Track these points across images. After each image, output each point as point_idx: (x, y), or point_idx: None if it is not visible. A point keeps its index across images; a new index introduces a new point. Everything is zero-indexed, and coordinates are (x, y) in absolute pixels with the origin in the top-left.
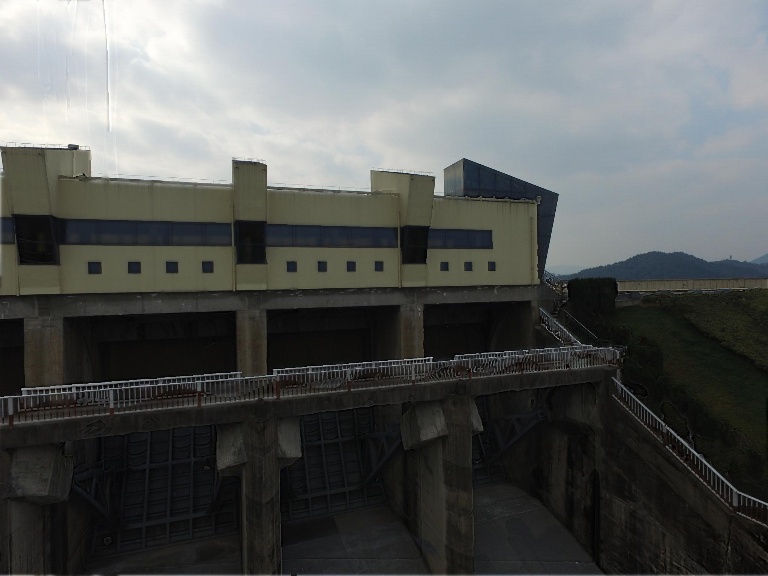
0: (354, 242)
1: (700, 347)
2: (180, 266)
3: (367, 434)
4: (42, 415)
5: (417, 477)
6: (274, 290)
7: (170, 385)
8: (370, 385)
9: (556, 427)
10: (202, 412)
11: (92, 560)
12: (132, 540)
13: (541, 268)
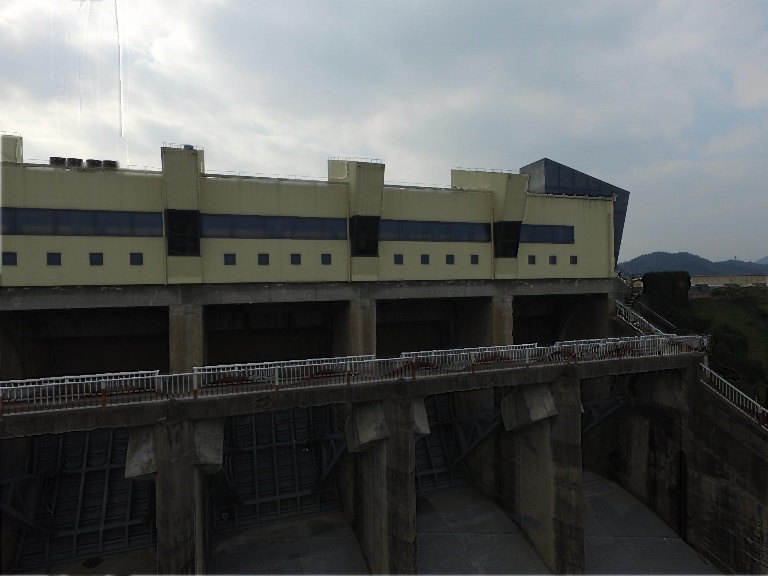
0: (452, 236)
1: None
2: (302, 258)
3: (454, 419)
4: (220, 390)
5: (515, 457)
6: (383, 281)
7: (324, 365)
8: (490, 368)
9: (637, 412)
10: (351, 390)
11: (215, 533)
12: (247, 516)
13: (614, 262)
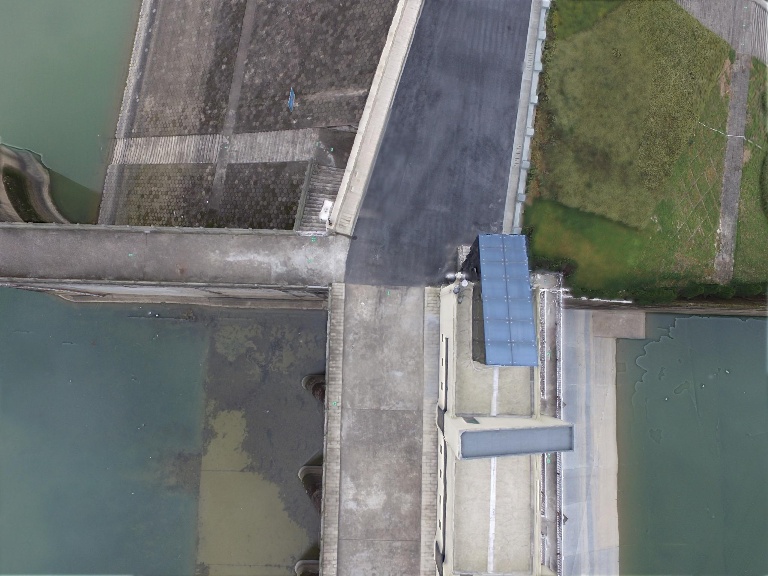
0: None
1: (570, 220)
2: None
3: None
4: None
5: None
6: None
7: None
8: None
9: None
10: None
11: None
12: None
13: None
